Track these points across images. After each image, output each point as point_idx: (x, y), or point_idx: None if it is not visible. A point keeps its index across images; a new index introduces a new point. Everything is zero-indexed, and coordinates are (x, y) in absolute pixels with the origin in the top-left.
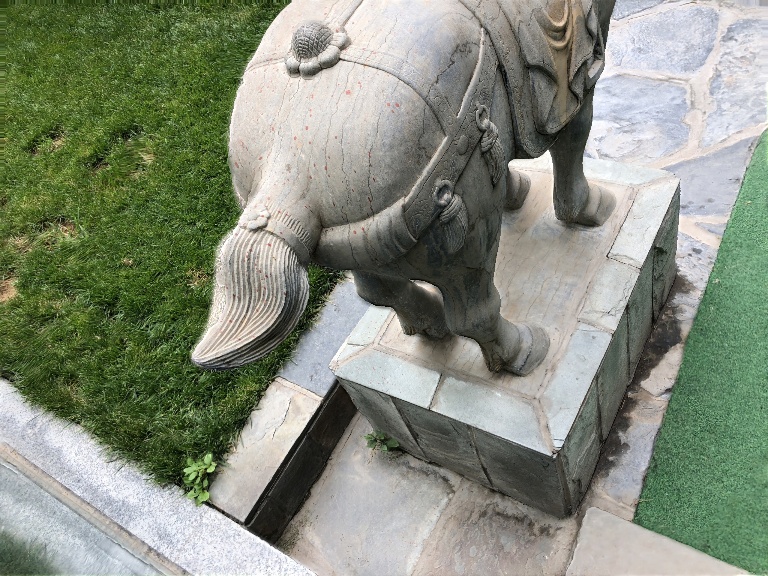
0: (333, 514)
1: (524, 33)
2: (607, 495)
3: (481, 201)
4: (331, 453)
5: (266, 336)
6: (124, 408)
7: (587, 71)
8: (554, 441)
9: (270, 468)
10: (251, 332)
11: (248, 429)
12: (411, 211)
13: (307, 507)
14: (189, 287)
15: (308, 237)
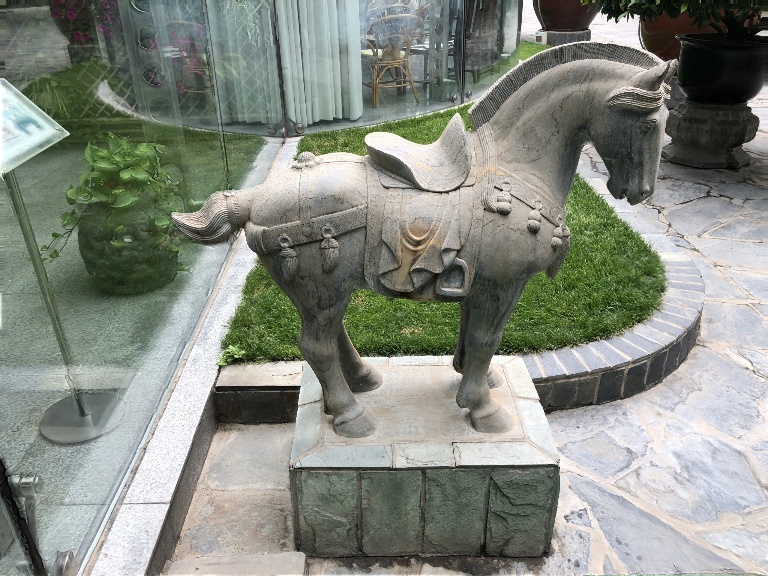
0: (251, 440)
1: (387, 223)
2: (325, 570)
3: (312, 270)
4: (289, 422)
5: (196, 230)
6: (258, 310)
7: (440, 283)
8: (299, 462)
9: (252, 383)
10: (193, 224)
11: (272, 364)
12: (266, 235)
13: (250, 427)
14: (351, 299)
15: (238, 215)
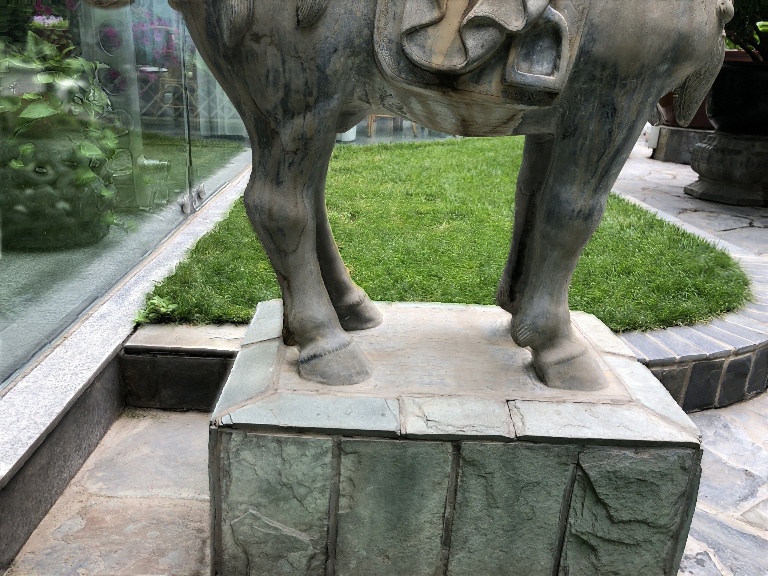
0: (170, 430)
1: None
2: None
3: (277, 21)
4: None
5: None
6: None
7: (514, 58)
8: (228, 415)
9: (181, 344)
10: None
11: (215, 326)
12: None
13: (172, 414)
14: None
15: None
